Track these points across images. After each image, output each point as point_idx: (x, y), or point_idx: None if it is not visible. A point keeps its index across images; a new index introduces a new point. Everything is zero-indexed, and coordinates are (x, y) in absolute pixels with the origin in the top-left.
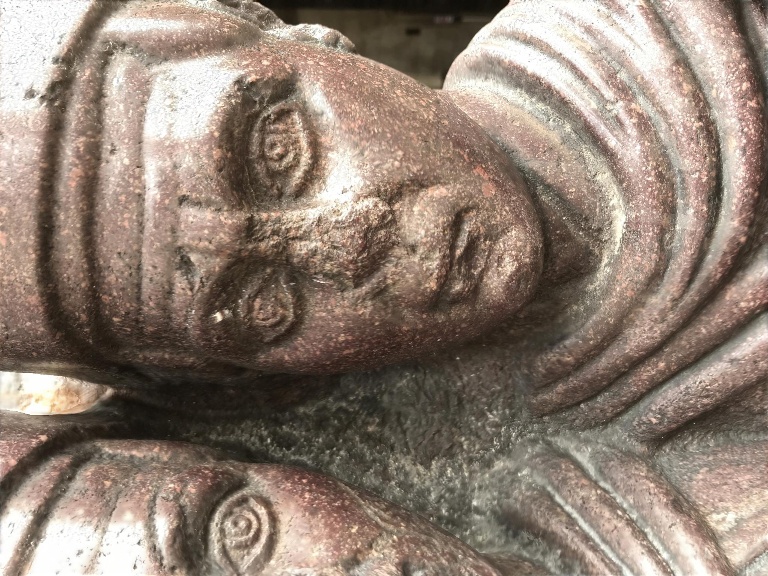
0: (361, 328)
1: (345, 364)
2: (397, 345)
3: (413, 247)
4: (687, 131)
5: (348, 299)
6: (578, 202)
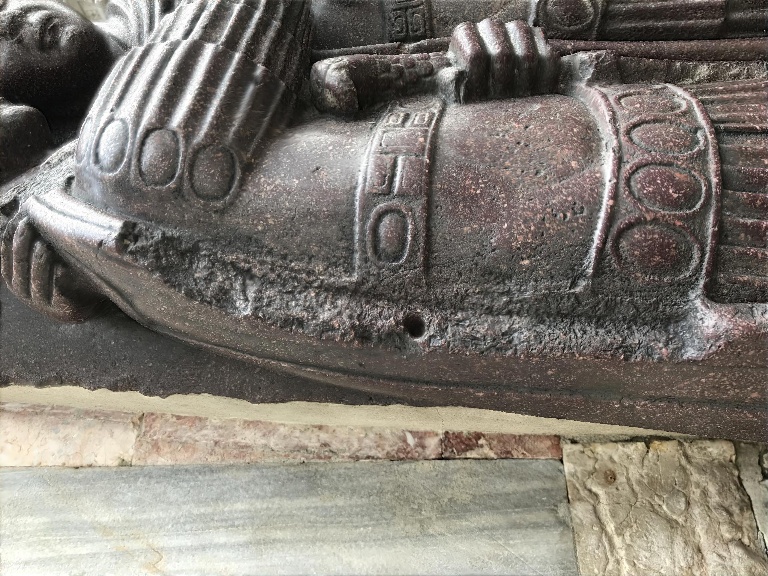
0: (16, 57)
1: (16, 81)
2: (33, 69)
3: (31, 24)
4: (144, 0)
5: (9, 44)
6: (123, 39)
